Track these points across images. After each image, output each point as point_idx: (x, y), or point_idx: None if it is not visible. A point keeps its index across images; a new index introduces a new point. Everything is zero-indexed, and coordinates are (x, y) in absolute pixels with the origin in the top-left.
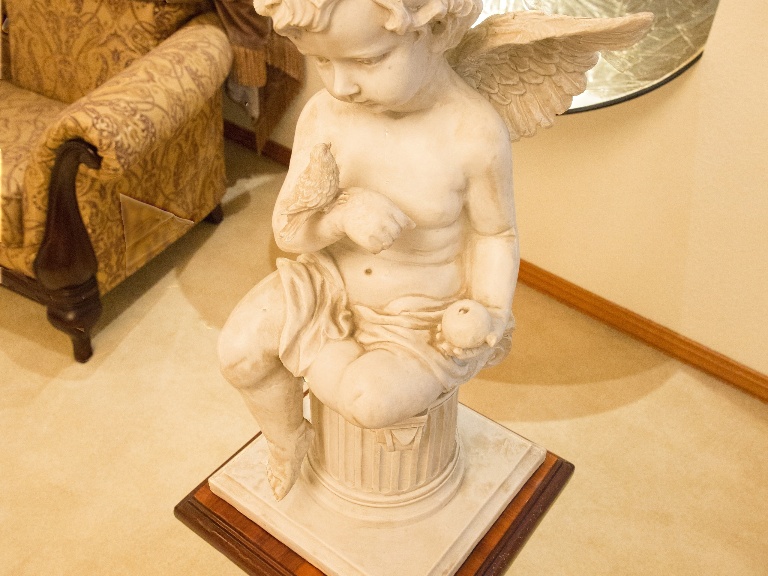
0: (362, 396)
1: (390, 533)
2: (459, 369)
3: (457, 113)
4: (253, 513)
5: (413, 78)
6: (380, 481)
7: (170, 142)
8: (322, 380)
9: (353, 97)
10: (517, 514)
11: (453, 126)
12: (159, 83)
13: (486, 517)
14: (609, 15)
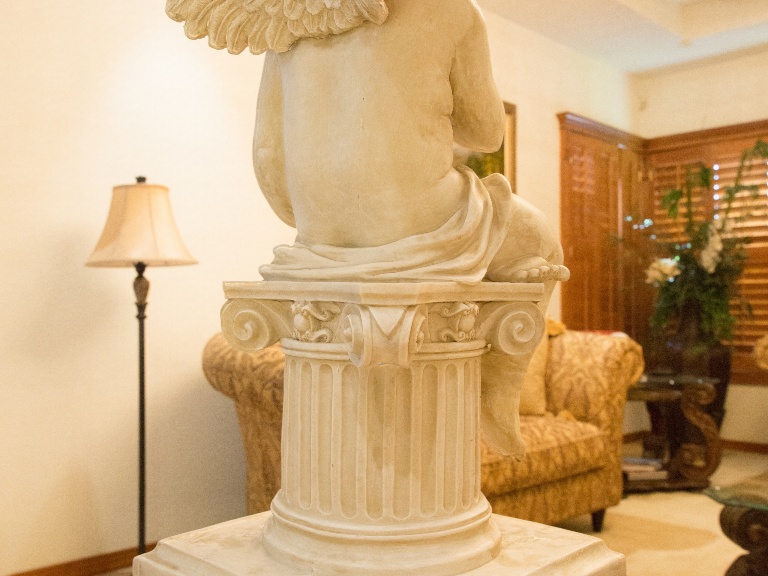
0: None
1: None
2: None
3: None
4: None
5: None
6: None
7: None
8: None
9: None
10: None
11: None
12: None
13: None
14: None
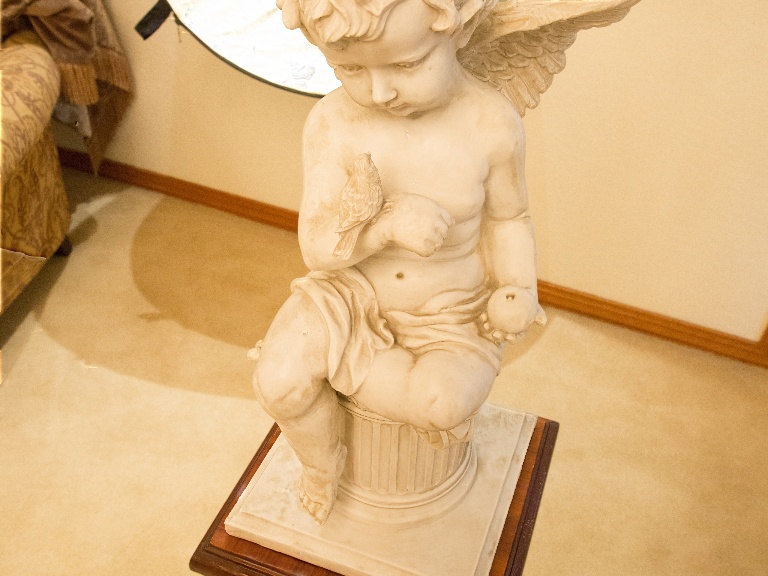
0: (438, 400)
1: (429, 529)
2: None
3: (475, 105)
4: (284, 544)
5: (447, 76)
6: (415, 481)
7: None
8: (382, 393)
9: (389, 103)
10: (529, 481)
11: (473, 118)
12: None
13: (508, 491)
14: None
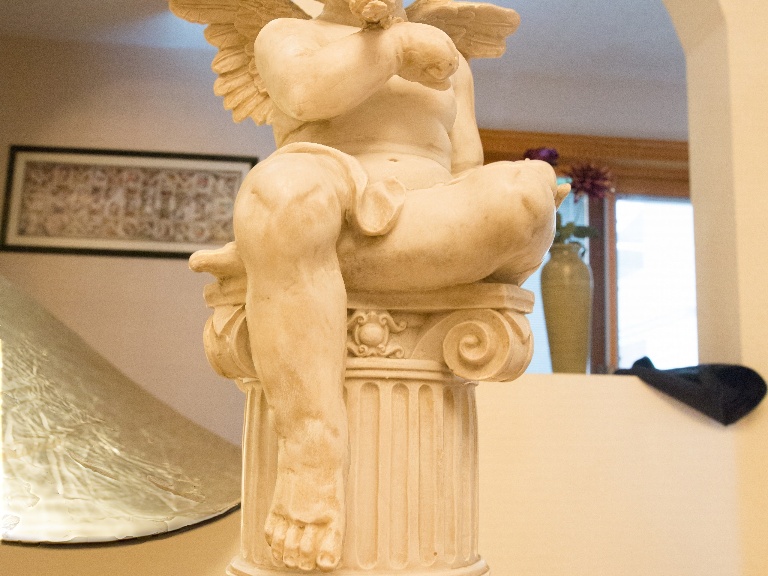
0: (522, 172)
1: None
2: None
3: None
4: None
5: None
6: None
7: None
8: (437, 203)
9: None
10: None
11: None
12: None
13: None
14: (162, 469)
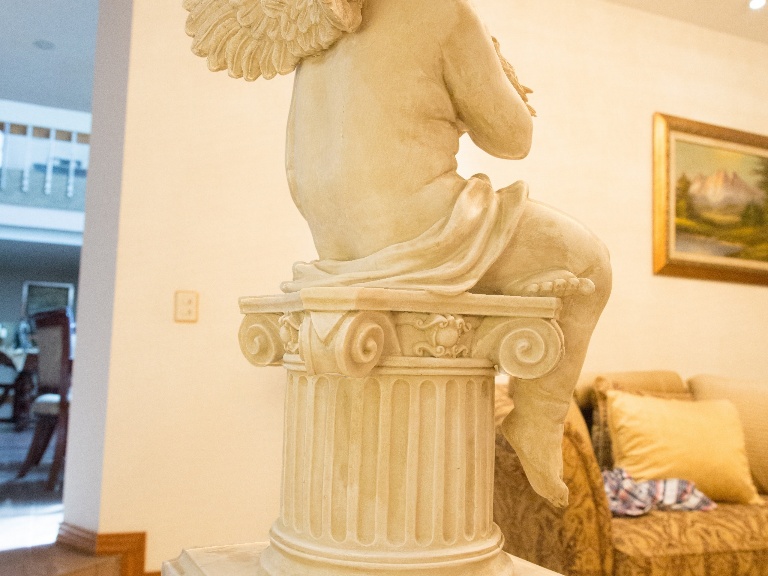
0: None
1: None
2: None
3: None
4: None
5: None
6: None
7: None
8: None
9: None
10: None
11: None
12: None
13: None
14: None
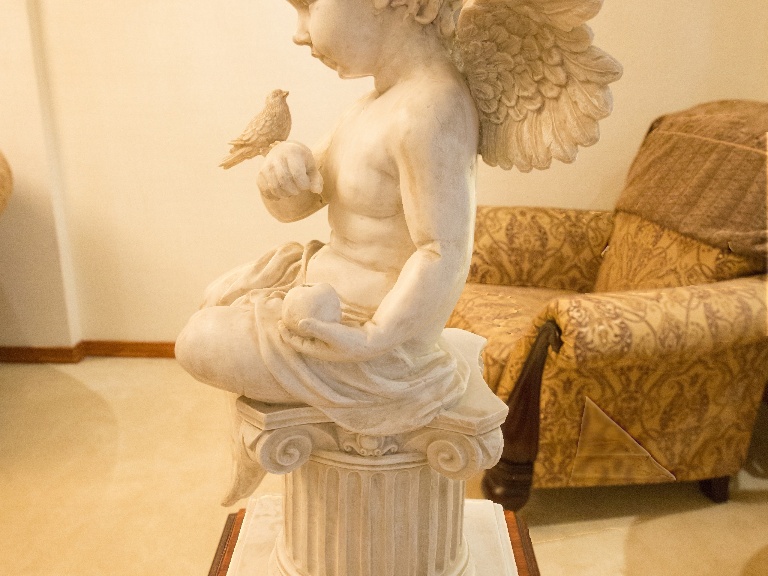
0: None
1: None
2: (310, 376)
3: (407, 88)
4: None
5: (342, 26)
6: (295, 544)
7: (668, 376)
8: None
9: None
10: None
11: None
12: (663, 305)
13: None
14: None
